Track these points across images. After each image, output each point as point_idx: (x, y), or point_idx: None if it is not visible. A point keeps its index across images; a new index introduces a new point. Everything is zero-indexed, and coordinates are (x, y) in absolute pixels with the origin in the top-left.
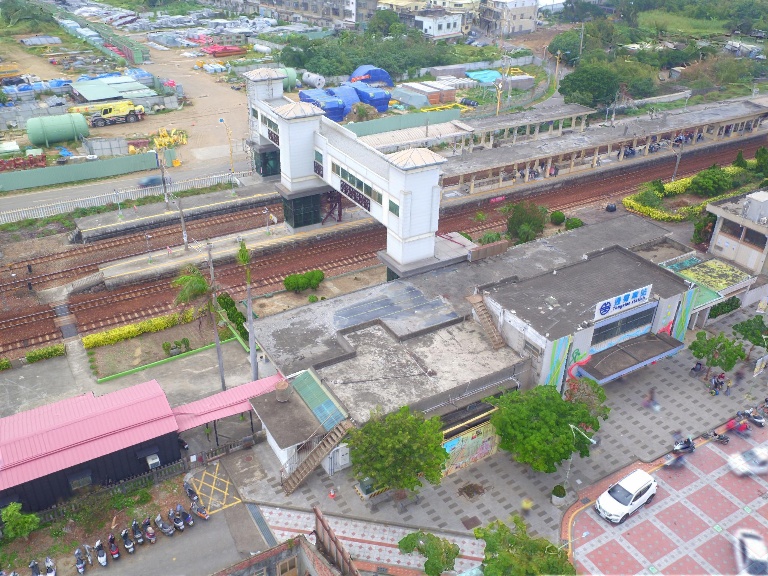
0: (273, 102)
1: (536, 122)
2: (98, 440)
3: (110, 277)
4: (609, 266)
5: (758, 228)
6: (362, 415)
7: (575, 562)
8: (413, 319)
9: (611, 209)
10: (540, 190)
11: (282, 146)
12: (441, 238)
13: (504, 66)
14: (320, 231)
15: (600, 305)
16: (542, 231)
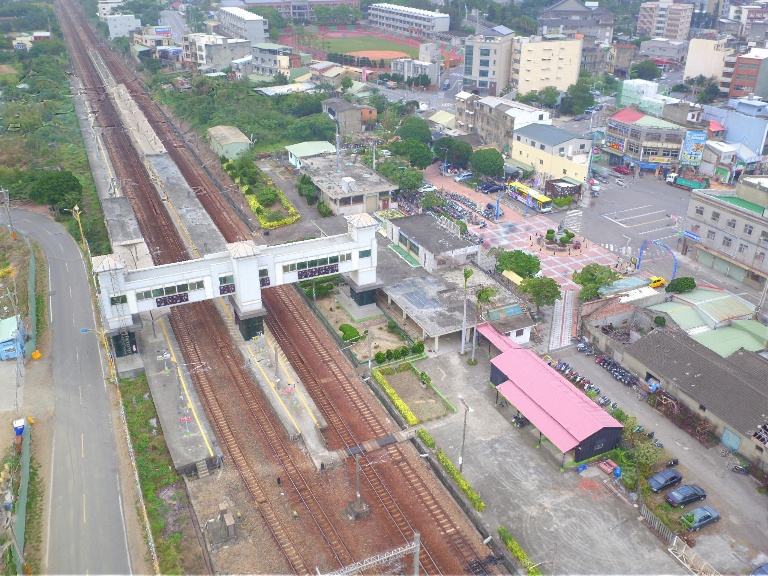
0: (135, 278)
1: None
2: (546, 368)
3: None
4: (406, 226)
5: (361, 193)
6: None
7: (561, 287)
8: (428, 288)
9: None
10: None
11: (245, 281)
12: None
13: (7, 200)
14: None
15: None
16: None
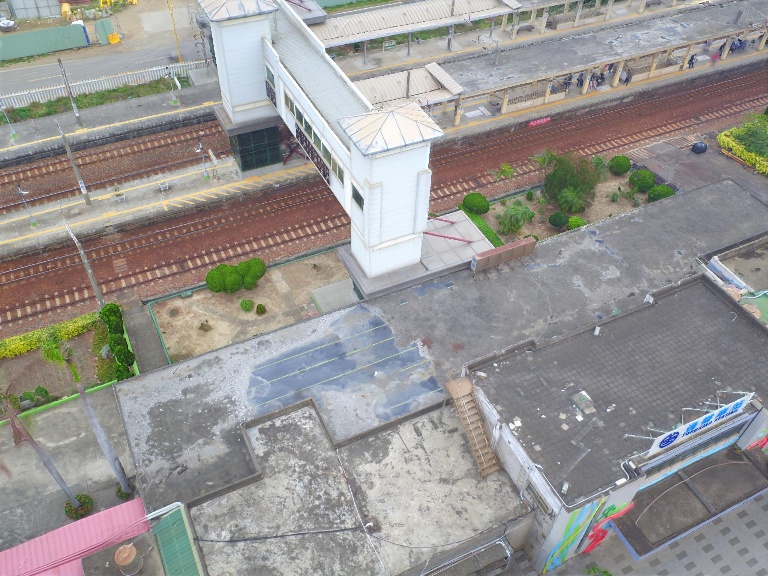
0: None
1: None
2: None
3: None
4: (685, 319)
5: None
6: None
7: None
8: (369, 390)
9: (699, 150)
10: (602, 106)
11: (217, 56)
12: (438, 223)
13: None
14: (280, 175)
15: (661, 438)
16: (593, 196)
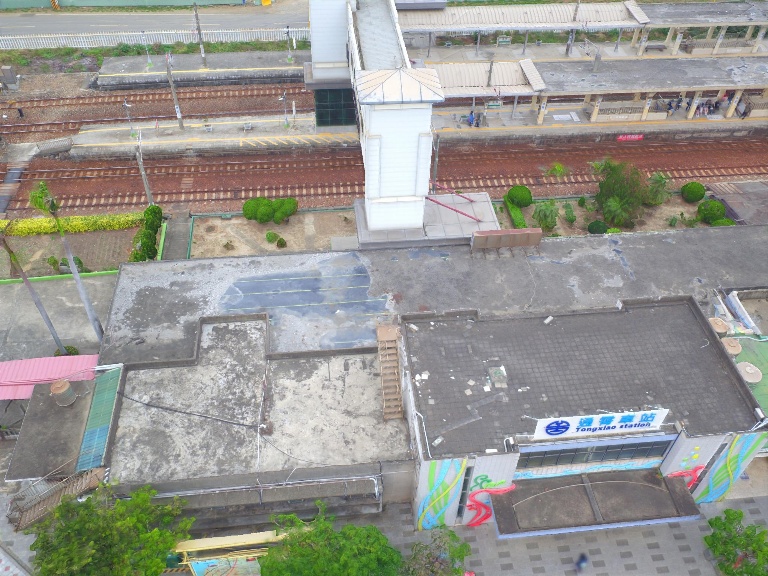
0: None
1: (760, 23)
2: None
3: (79, 145)
4: (649, 333)
5: None
6: (126, 468)
7: None
8: (324, 323)
9: None
10: (707, 135)
11: None
12: (458, 198)
13: None
14: (350, 136)
15: (546, 422)
16: (644, 213)
